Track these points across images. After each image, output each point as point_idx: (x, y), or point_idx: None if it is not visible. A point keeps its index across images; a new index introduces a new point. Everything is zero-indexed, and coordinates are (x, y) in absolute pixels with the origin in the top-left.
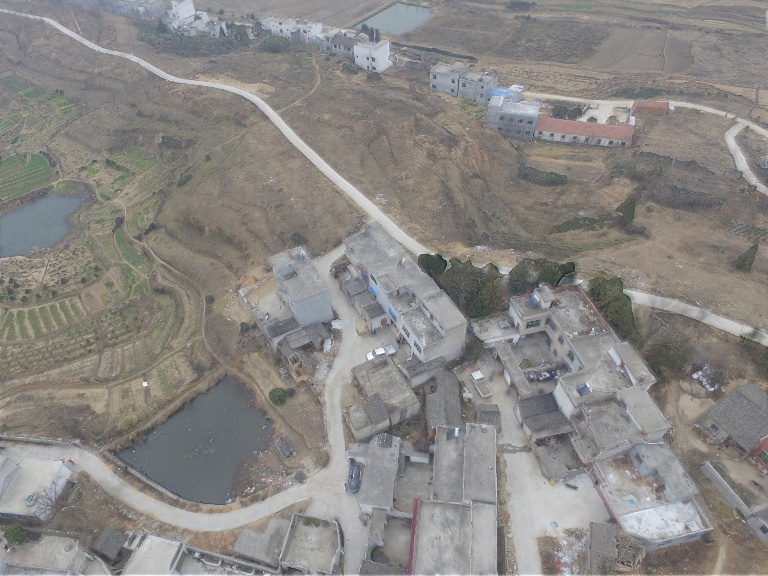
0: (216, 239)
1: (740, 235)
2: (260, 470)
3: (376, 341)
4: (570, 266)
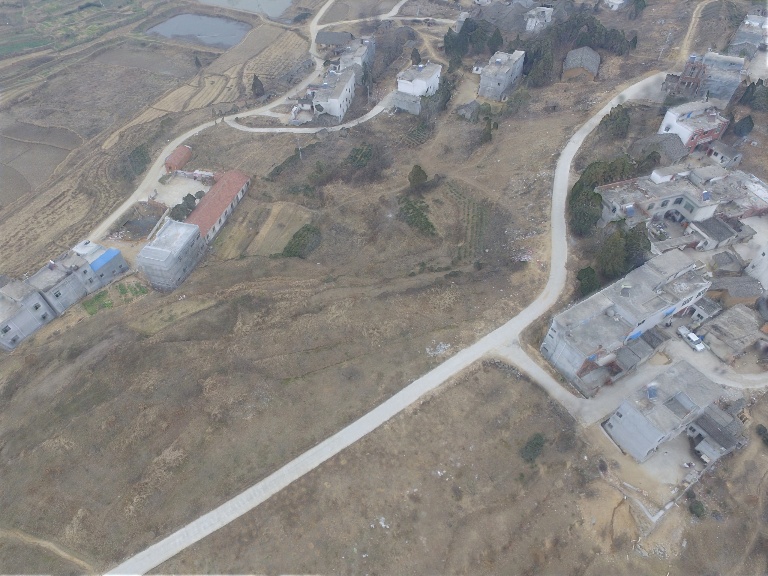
0: None
1: (421, 141)
2: None
3: (673, 346)
4: None
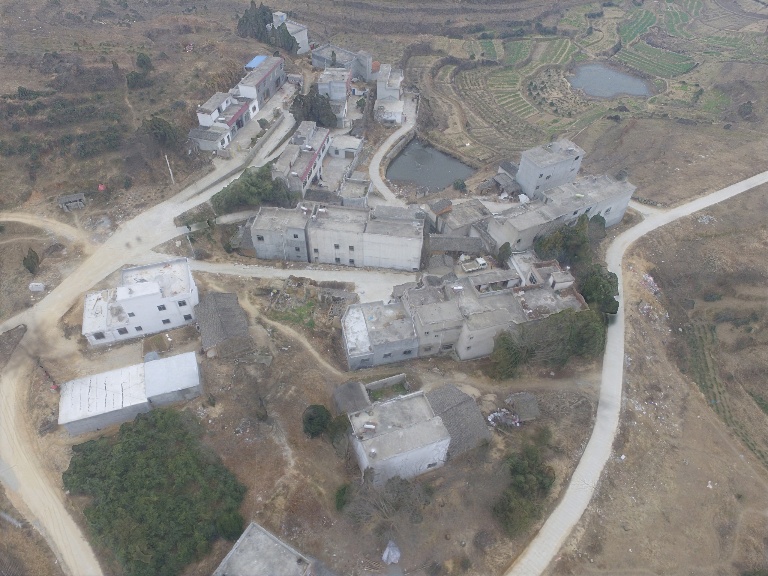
0: (613, 147)
1: None
2: (408, 188)
3: None
4: (613, 303)
